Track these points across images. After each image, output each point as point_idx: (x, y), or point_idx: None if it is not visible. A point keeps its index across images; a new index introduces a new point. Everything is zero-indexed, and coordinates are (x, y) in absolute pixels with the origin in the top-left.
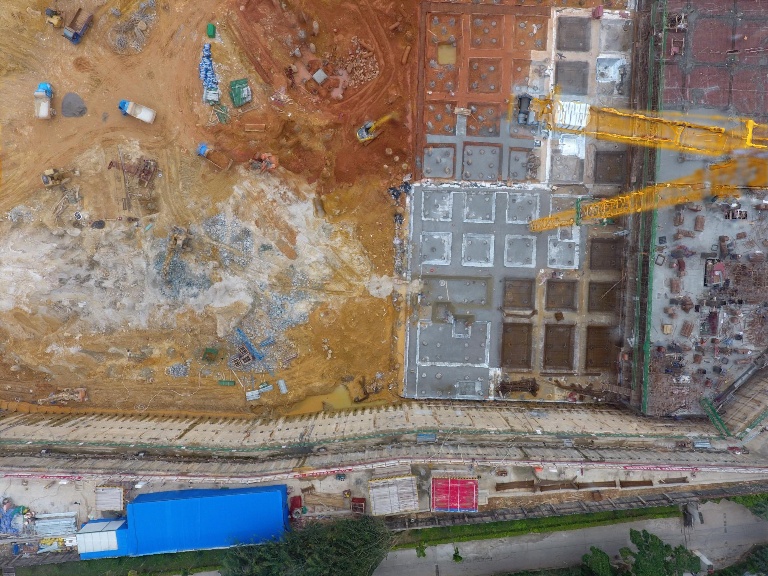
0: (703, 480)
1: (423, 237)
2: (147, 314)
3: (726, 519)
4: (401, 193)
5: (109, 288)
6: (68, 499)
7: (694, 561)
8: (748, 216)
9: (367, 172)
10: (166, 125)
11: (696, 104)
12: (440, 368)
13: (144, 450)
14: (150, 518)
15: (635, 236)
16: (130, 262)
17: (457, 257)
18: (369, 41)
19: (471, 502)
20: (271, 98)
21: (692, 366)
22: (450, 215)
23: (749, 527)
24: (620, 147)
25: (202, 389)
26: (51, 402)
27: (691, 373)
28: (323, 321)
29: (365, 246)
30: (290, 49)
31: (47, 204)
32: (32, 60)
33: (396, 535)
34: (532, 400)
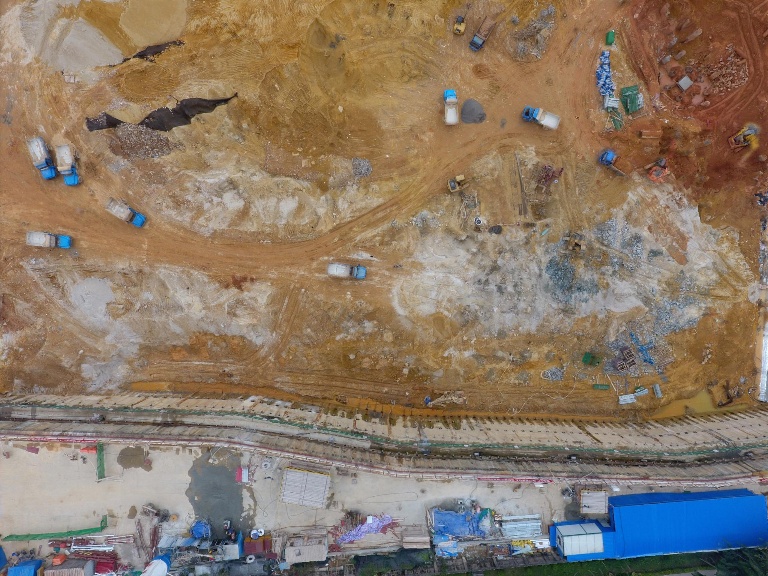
0: None
1: None
2: (541, 318)
3: None
4: None
5: (507, 292)
6: (532, 502)
7: None
8: None
9: (735, 178)
10: (562, 131)
11: None
12: None
13: (575, 453)
14: (636, 521)
15: None
16: (527, 267)
17: None
18: (741, 48)
19: None
20: None
21: None
22: None
23: None
24: None
25: (574, 393)
26: None
27: None
28: (715, 326)
29: (743, 252)
30: (657, 56)
31: (447, 209)
32: (432, 67)
33: None
34: None
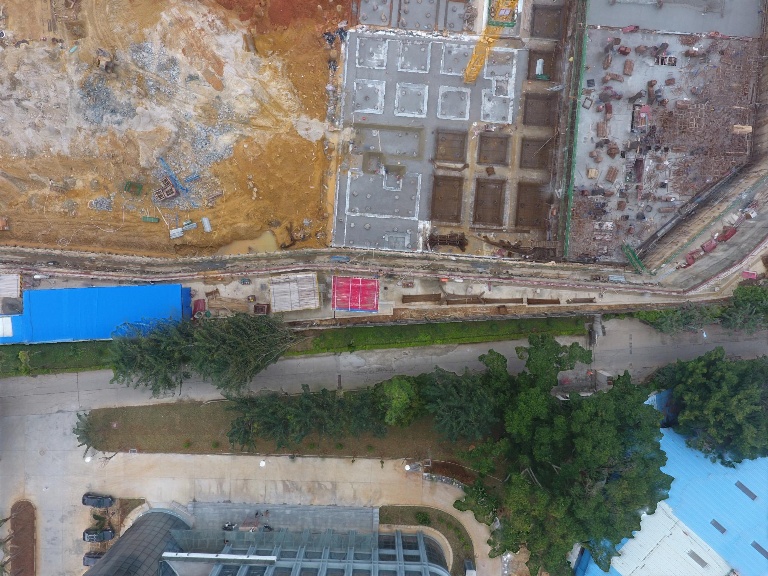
0: (611, 301)
1: (357, 85)
2: (69, 138)
3: (632, 340)
4: (335, 38)
5: (31, 109)
6: None
7: (585, 352)
8: (677, 63)
9: (302, 15)
10: None
11: None
12: (369, 218)
13: (54, 260)
14: (46, 306)
15: (568, 88)
16: (53, 84)
17: (390, 106)
18: None
19: (372, 303)
20: None
21: (616, 213)
22: (385, 63)
23: (654, 349)
24: (558, 1)
25: (126, 226)
26: None
27: (614, 220)
28: (247, 153)
29: (295, 85)
30: None
31: None
32: None
33: (296, 335)
34: (460, 254)
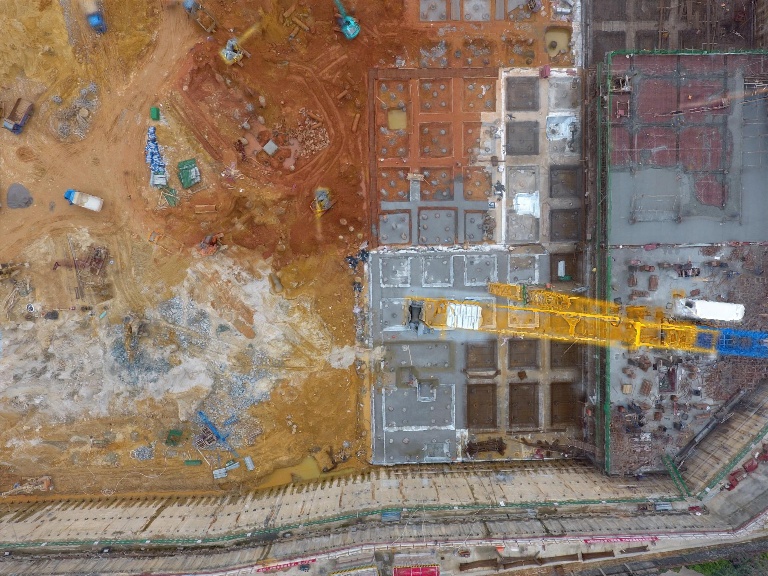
0: (663, 547)
1: (383, 304)
2: (107, 402)
3: None
4: (358, 262)
5: (66, 379)
6: None
7: None
8: (701, 273)
9: (323, 243)
10: (115, 211)
11: (644, 165)
12: (407, 433)
13: (109, 546)
14: None
15: (592, 294)
16: (86, 351)
17: None
18: (317, 111)
19: None
20: (221, 174)
21: (653, 423)
22: (409, 281)
23: None
24: (574, 204)
25: (169, 469)
26: (16, 492)
27: (652, 430)
28: (285, 399)
29: (324, 319)
30: (239, 122)
31: None
32: None
33: None
34: (500, 459)
